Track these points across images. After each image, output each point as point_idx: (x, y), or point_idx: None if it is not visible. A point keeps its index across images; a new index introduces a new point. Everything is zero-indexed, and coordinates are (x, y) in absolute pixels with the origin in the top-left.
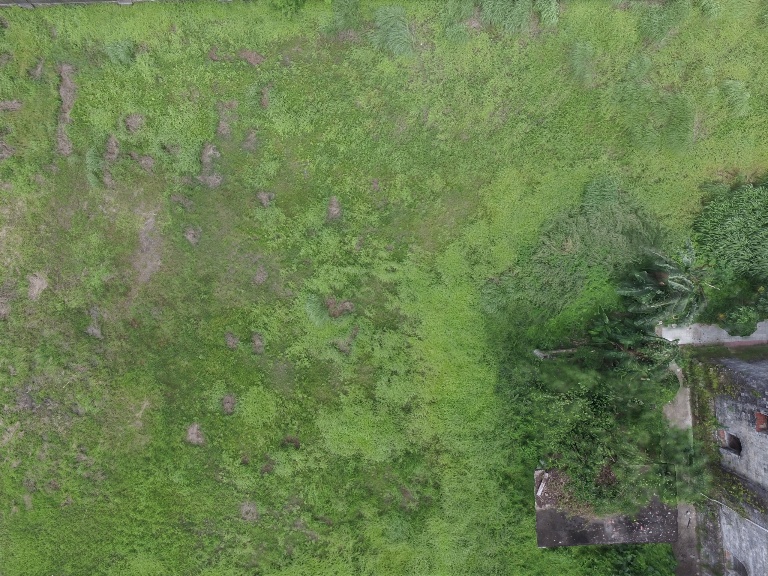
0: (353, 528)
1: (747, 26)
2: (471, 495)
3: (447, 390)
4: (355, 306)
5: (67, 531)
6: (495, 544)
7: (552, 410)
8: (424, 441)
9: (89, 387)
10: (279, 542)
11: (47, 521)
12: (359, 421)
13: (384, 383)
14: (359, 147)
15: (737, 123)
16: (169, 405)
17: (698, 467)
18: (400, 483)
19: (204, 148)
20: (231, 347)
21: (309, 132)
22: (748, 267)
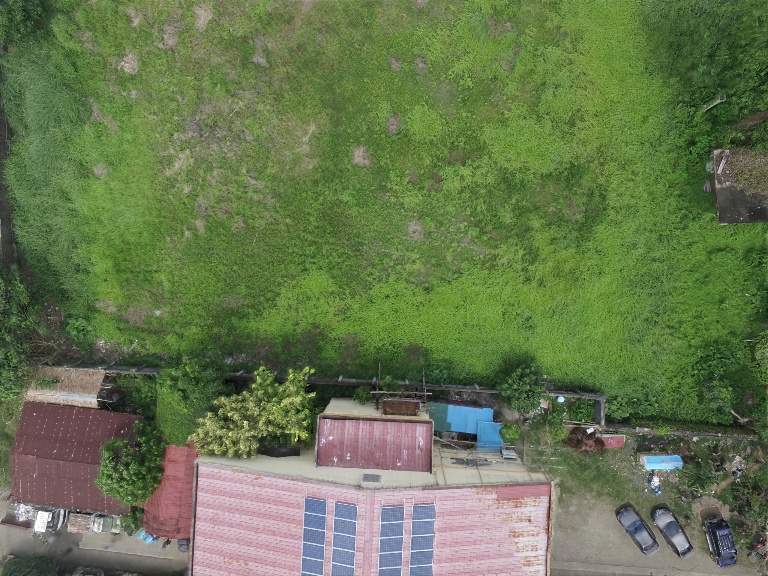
0: (521, 240)
1: None
2: (639, 200)
3: (611, 102)
4: (516, 26)
5: (239, 254)
6: (663, 248)
7: None
8: (588, 154)
9: (256, 114)
10: (448, 258)
11: (219, 245)
12: (526, 133)
13: (550, 94)
14: None
15: None
16: (335, 129)
17: None
18: (566, 195)
19: None
20: (394, 71)
21: None
22: None
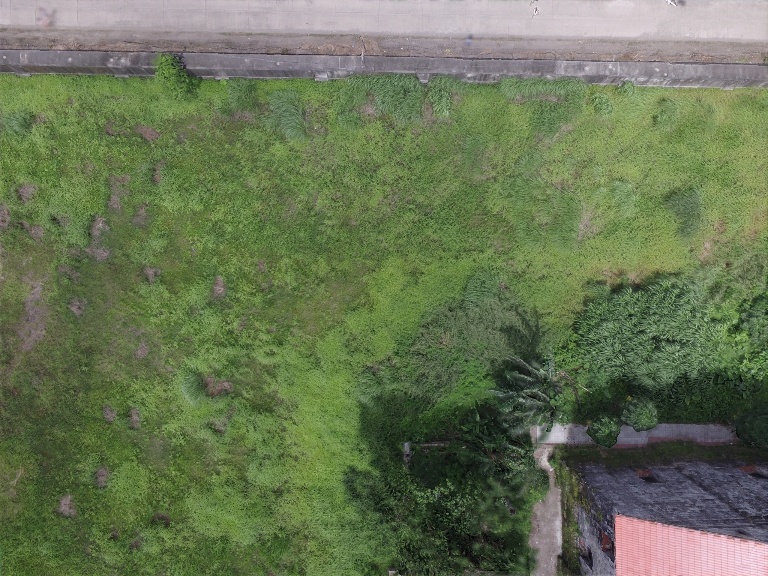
0: None
1: (639, 127)
2: None
3: (318, 477)
4: (233, 386)
5: None
6: None
7: (391, 522)
8: (294, 526)
9: None
10: None
11: None
12: (228, 503)
13: (255, 467)
14: (247, 228)
15: (624, 224)
16: (44, 475)
17: (563, 571)
18: (267, 567)
19: (94, 221)
20: (109, 420)
21: (198, 210)
22: (621, 373)
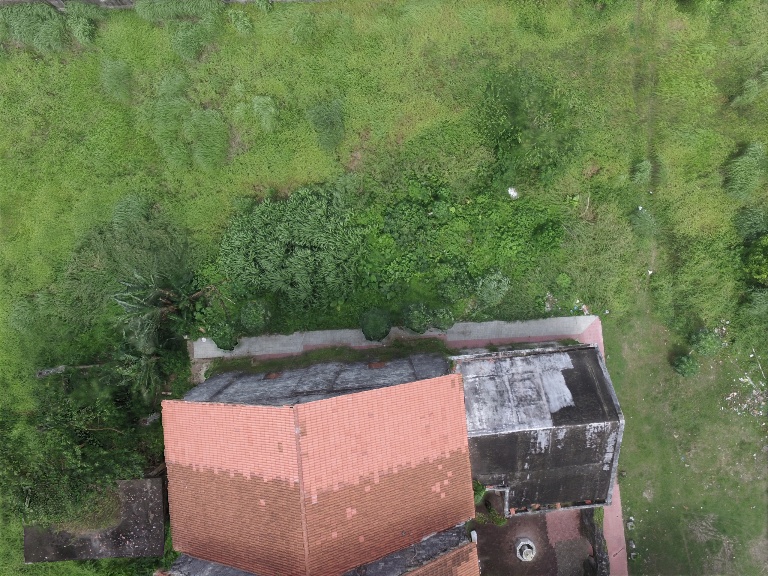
0: None
1: (282, 42)
2: None
3: None
4: None
5: None
6: None
7: None
8: None
9: None
10: None
11: None
12: None
13: None
14: None
15: (272, 138)
16: None
17: None
18: None
19: None
20: None
21: None
22: (258, 281)
